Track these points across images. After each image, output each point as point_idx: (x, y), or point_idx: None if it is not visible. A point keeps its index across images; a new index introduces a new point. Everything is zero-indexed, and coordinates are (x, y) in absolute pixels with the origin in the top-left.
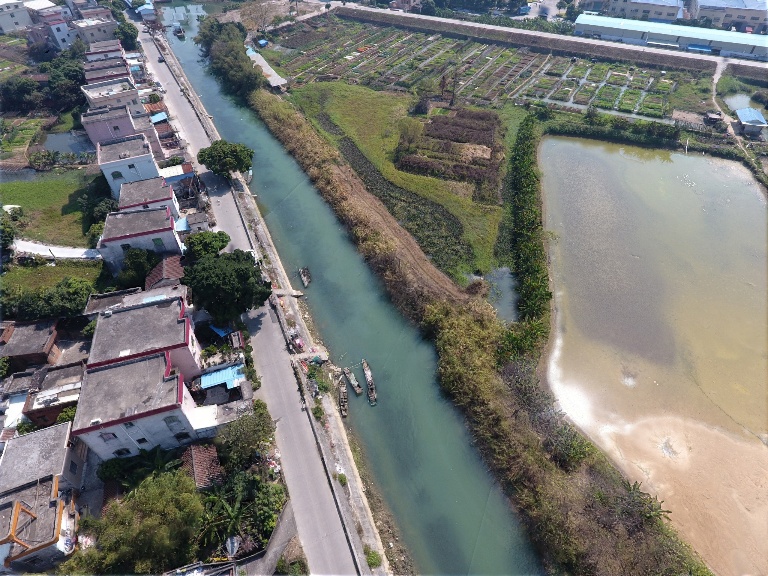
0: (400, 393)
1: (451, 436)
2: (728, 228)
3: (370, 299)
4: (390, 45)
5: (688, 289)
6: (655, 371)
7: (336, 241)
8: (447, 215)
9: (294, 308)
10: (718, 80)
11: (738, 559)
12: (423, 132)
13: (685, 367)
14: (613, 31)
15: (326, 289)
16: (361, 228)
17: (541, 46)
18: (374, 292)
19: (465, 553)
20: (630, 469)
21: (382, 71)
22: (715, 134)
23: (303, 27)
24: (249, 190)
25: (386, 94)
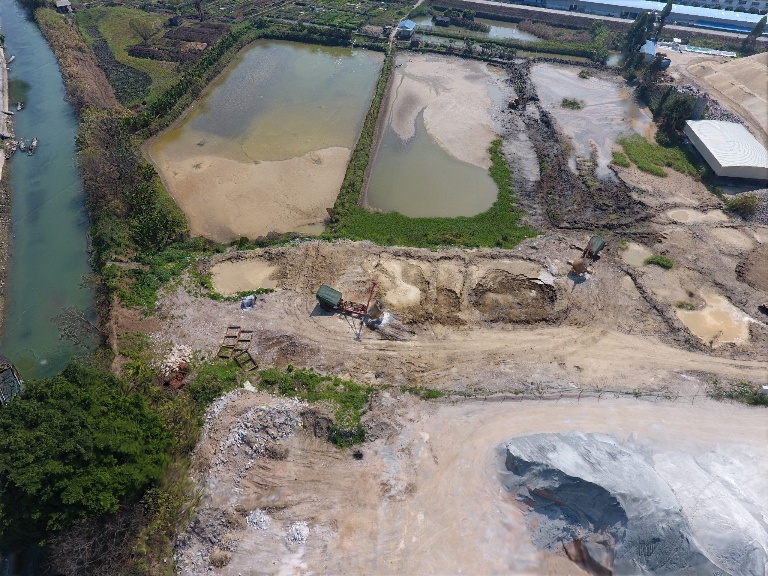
0: (51, 150)
1: (70, 164)
2: (337, 83)
3: (60, 115)
4: None
5: (279, 109)
6: (221, 140)
7: (55, 90)
8: (146, 78)
9: (0, 117)
10: None
11: (196, 197)
12: (164, 35)
13: (241, 139)
14: None
15: (33, 111)
16: (72, 80)
17: None
18: (65, 112)
19: (46, 200)
20: (168, 173)
21: None
22: (380, 37)
23: None
24: (6, 67)
25: (153, 14)
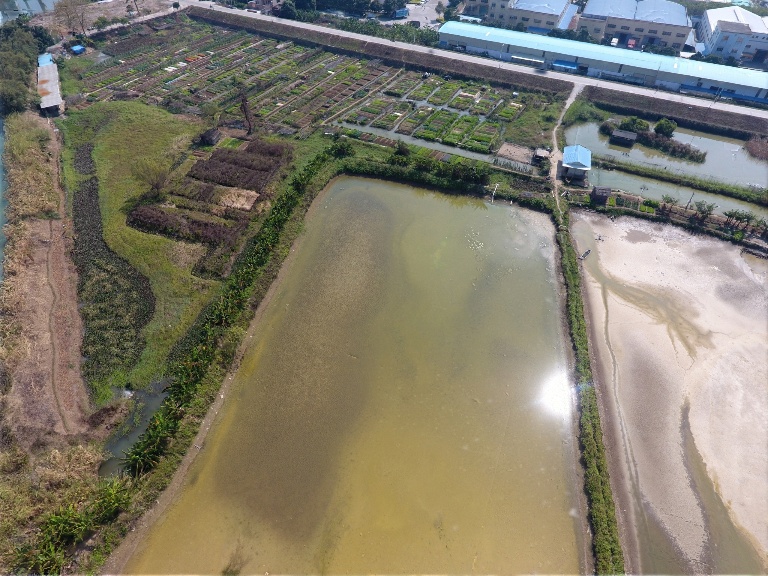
0: None
1: None
2: (489, 312)
3: None
4: (228, 54)
5: (393, 409)
6: (277, 554)
7: None
8: (146, 294)
9: None
10: (569, 105)
11: None
12: (189, 172)
13: (321, 545)
14: (477, 42)
15: None
16: (5, 319)
17: (394, 59)
18: None
19: None
20: None
21: (193, 88)
22: (534, 177)
23: (141, 30)
24: None
25: (179, 118)
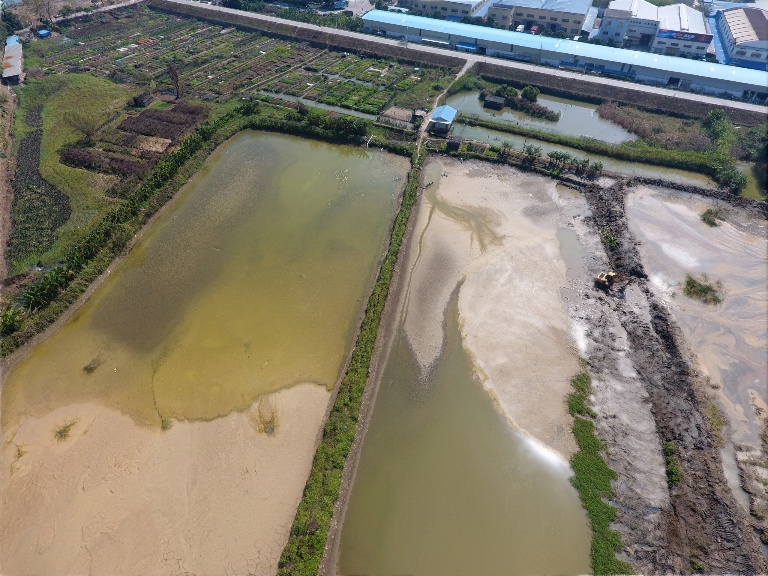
0: None
1: None
2: (335, 222)
3: None
4: (176, 37)
5: (237, 280)
6: (125, 359)
7: None
8: (65, 207)
9: None
10: None
11: (28, 534)
12: (118, 125)
13: (159, 355)
14: (394, 27)
15: None
16: None
17: (320, 41)
18: None
19: None
20: (7, 452)
21: (138, 64)
22: (407, 131)
23: (103, 18)
24: None
25: (120, 87)
